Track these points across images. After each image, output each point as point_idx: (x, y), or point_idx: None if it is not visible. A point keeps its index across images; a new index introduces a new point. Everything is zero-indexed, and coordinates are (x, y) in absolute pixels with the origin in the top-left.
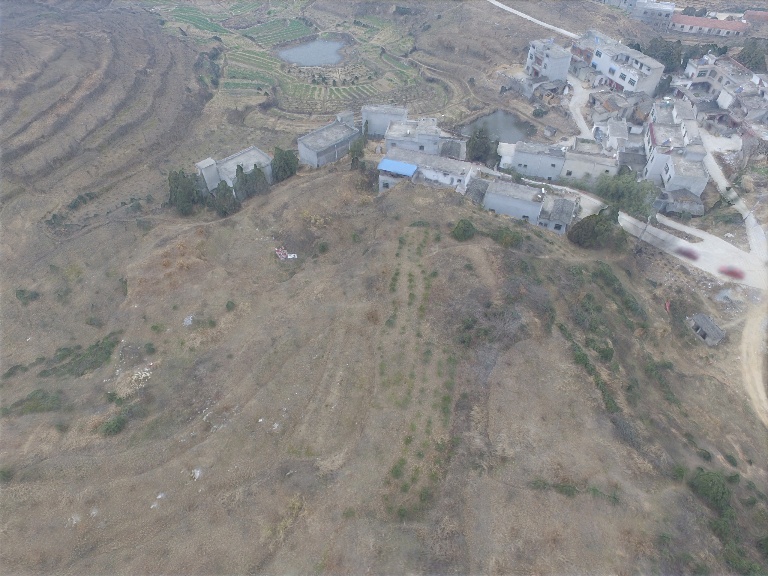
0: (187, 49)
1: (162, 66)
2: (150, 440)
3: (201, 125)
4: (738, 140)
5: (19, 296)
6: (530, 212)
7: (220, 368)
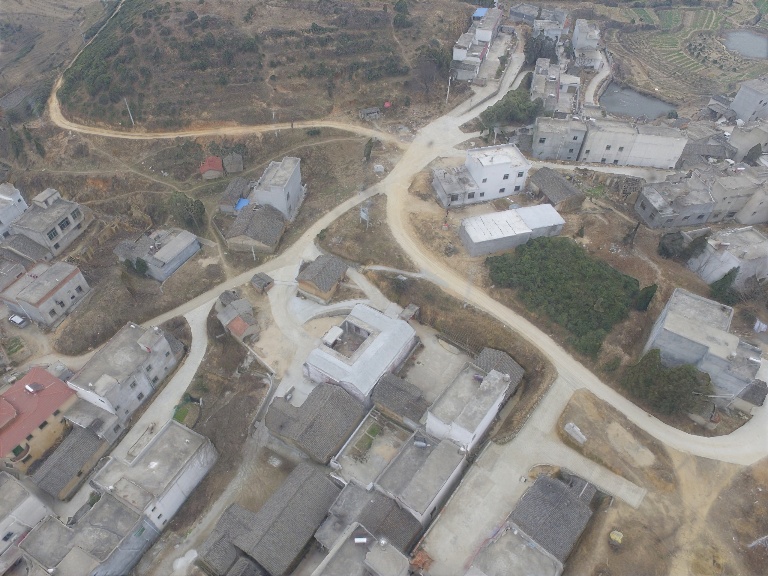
0: None
1: None
2: None
3: (562, 3)
4: None
5: None
6: None
7: None
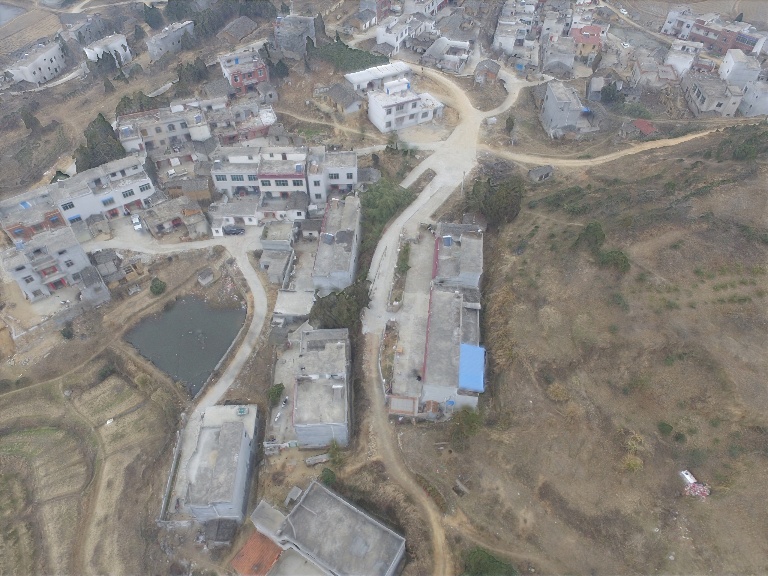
0: None
1: None
2: None
3: None
4: (251, 143)
5: None
6: None
7: None
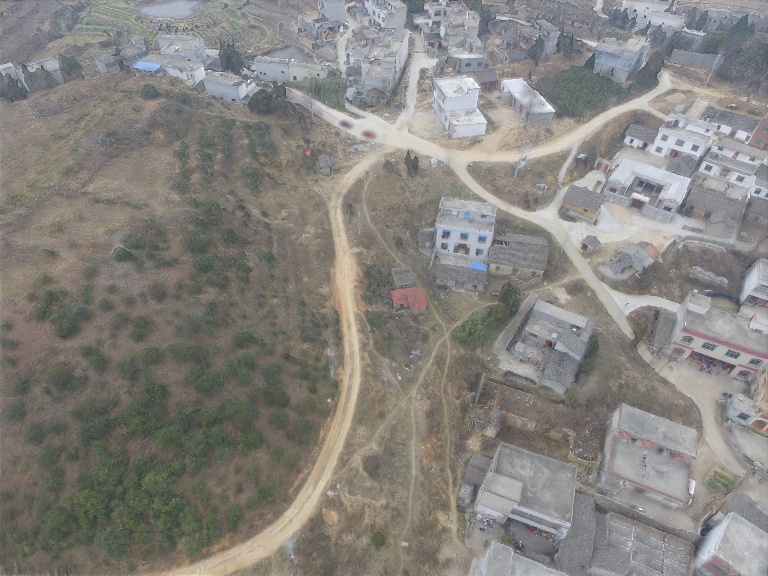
0: (53, 1)
1: (22, 12)
2: None
3: (40, 55)
4: None
5: None
6: (234, 95)
7: None
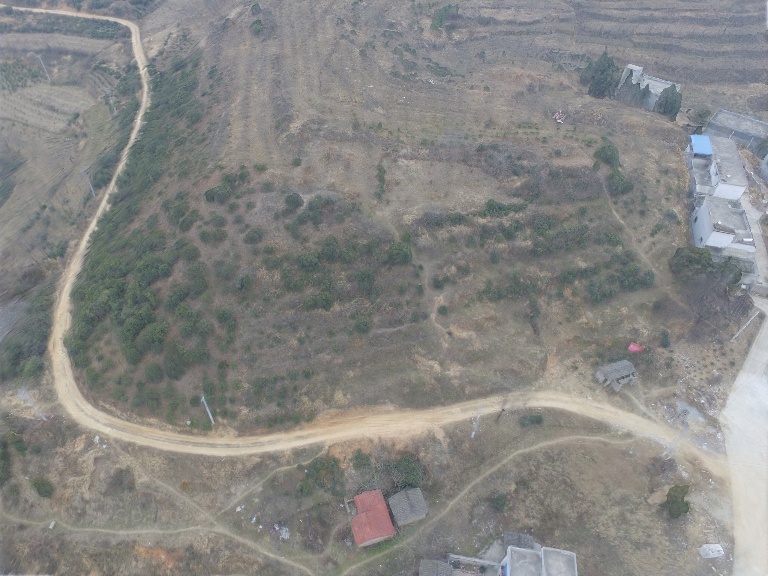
0: None
1: None
2: (391, 82)
3: (727, 86)
4: None
5: (480, 54)
6: None
7: None
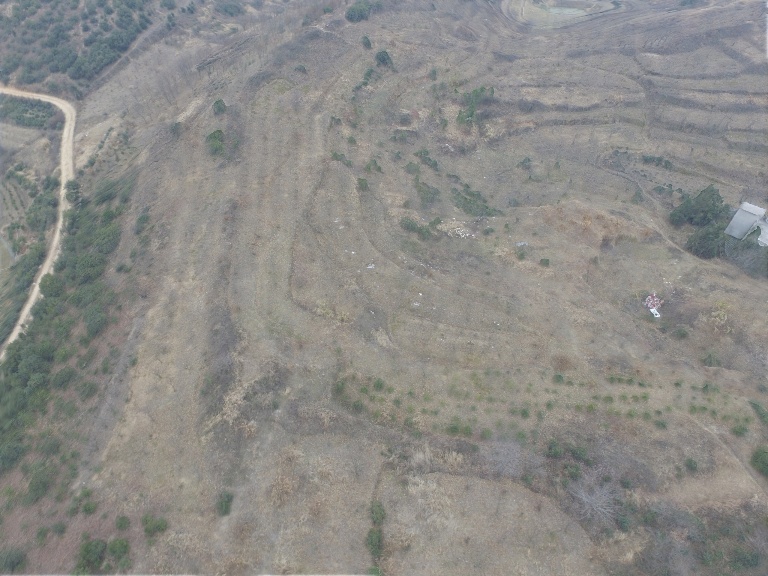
0: None
1: None
2: (401, 245)
3: None
4: None
5: (524, 161)
6: None
7: (473, 269)
